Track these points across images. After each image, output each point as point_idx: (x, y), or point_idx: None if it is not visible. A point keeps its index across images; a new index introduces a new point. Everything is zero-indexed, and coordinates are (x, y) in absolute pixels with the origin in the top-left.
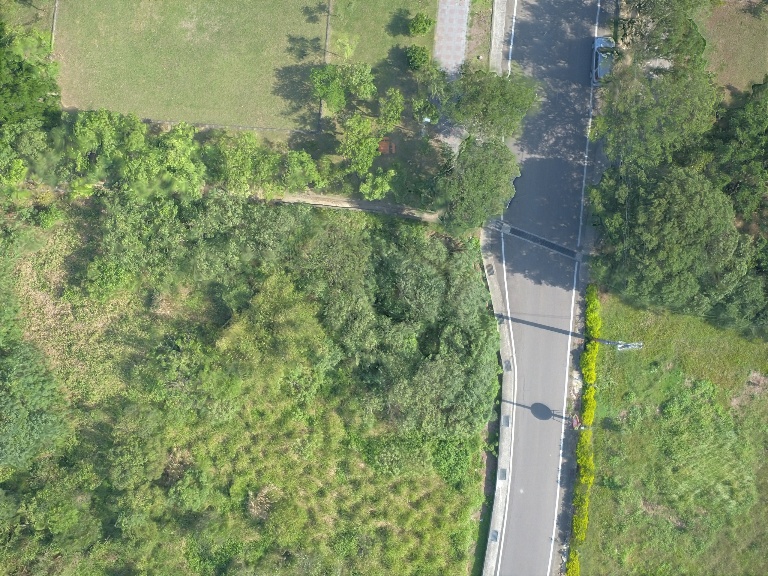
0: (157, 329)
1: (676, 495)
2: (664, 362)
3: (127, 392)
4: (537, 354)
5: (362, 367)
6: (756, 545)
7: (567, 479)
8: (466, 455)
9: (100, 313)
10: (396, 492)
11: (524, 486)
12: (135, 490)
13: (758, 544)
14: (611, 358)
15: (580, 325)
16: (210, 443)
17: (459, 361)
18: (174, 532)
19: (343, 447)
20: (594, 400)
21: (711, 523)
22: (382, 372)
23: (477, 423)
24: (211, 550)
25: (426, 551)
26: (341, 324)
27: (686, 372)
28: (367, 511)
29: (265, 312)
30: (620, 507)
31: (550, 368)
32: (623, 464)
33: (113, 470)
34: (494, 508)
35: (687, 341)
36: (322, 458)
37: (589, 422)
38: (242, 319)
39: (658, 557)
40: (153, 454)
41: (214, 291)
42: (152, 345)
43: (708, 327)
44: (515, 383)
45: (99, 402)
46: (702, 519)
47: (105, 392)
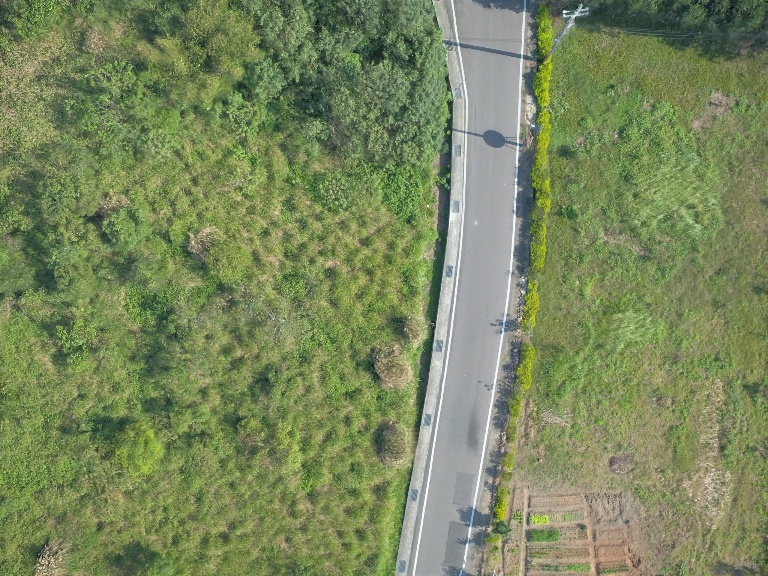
0: (91, 71)
1: (638, 221)
2: (621, 85)
3: (60, 137)
4: (488, 80)
5: (305, 96)
6: (724, 270)
7: (523, 208)
8: (417, 187)
9: (31, 57)
10: (344, 227)
11: (478, 217)
12: (67, 224)
13: (726, 269)
14: (566, 83)
15: (532, 47)
16: (148, 184)
17: (404, 76)
18: (111, 277)
19: (288, 186)
20: (549, 124)
21: (676, 249)
22: (324, 94)
23: (425, 144)
24: (148, 286)
25: (377, 289)
26: (278, 35)
27: (644, 94)
28: (314, 250)
29: (199, 28)
30: (580, 236)
31: (502, 93)
32: (582, 191)
33: (42, 200)
34: (448, 242)
35: (644, 63)
36: (266, 196)
37: (544, 146)
38: (175, 40)
39: (621, 288)
40: (86, 188)
41: (149, 29)
42: (85, 86)
43: (666, 47)
44: (466, 111)
45: (31, 150)
46: (666, 246)
47: (38, 139)
